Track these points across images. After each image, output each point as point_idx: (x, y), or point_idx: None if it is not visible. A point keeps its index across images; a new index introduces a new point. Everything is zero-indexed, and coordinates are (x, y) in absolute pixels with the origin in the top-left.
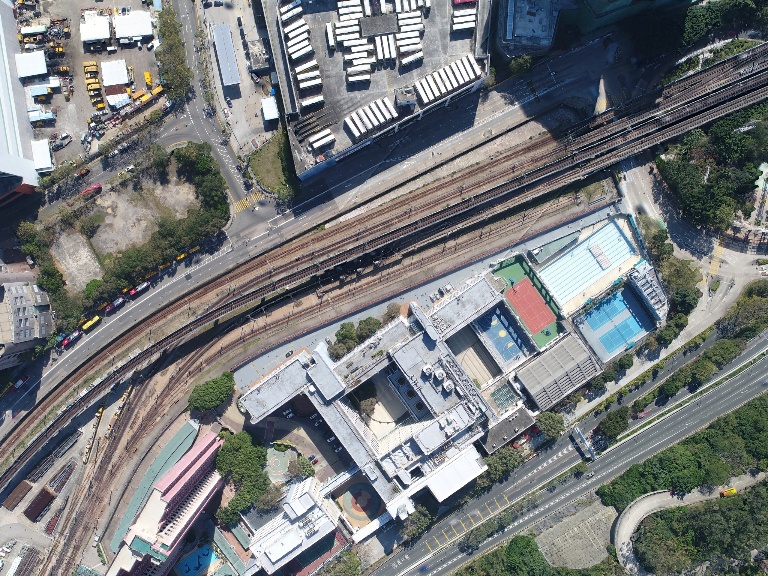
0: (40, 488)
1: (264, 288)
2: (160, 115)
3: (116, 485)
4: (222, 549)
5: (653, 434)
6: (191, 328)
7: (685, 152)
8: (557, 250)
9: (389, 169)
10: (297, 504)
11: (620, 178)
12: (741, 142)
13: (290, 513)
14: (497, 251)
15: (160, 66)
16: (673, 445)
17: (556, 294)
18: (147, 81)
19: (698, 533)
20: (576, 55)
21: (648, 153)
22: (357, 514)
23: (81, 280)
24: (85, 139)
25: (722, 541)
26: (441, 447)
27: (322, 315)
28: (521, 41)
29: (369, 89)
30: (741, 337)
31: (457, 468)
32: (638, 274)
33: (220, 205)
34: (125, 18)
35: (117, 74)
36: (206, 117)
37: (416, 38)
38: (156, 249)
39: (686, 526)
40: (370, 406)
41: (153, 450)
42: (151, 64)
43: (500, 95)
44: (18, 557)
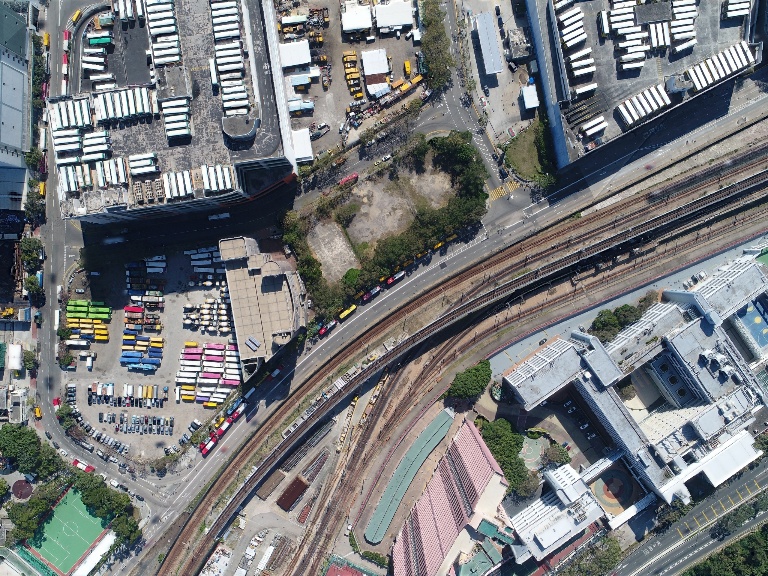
0: (293, 477)
1: (526, 276)
2: (420, 104)
3: (368, 474)
4: None
5: None
6: (453, 316)
7: None
8: None
9: (644, 157)
10: (571, 490)
11: None
12: None
13: (563, 499)
14: (750, 238)
15: (420, 55)
16: None
17: None
18: (407, 70)
19: None
20: None
21: None
22: (609, 501)
23: (336, 269)
24: (343, 128)
25: None
26: None
27: (575, 303)
28: None
29: (639, 77)
30: None
31: (732, 453)
32: None
33: None
34: (386, 7)
35: (377, 63)
36: (463, 106)
37: (690, 25)
38: (418, 238)
39: None
40: (633, 393)
41: (406, 438)
42: (409, 53)
43: (754, 83)
44: (271, 546)
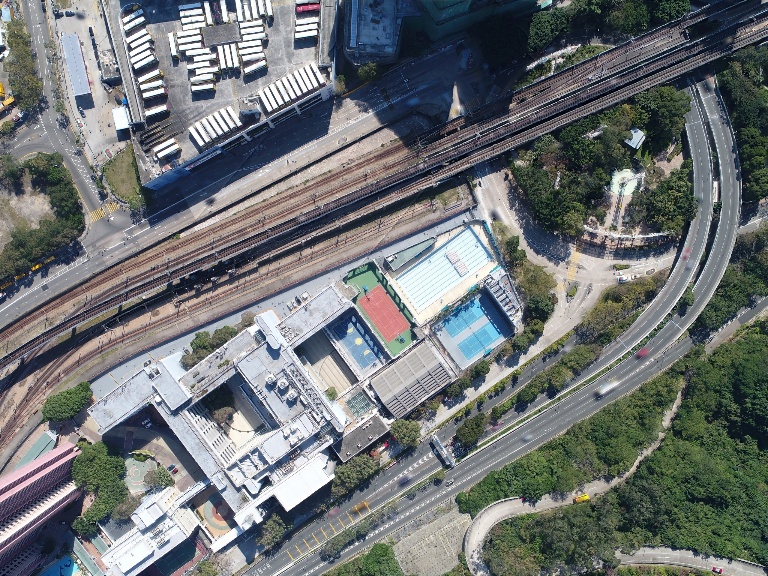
0: None
1: (116, 298)
2: (12, 126)
3: None
4: (82, 560)
5: (512, 440)
6: (44, 339)
7: (536, 158)
8: (412, 257)
9: (244, 178)
10: (145, 515)
11: (475, 184)
12: (589, 148)
13: (139, 524)
14: (353, 259)
15: None
16: (531, 451)
17: (414, 301)
18: None
19: (546, 540)
20: (429, 62)
21: (503, 159)
22: (218, 523)
23: None
24: None
25: (567, 548)
26: (289, 456)
27: (180, 324)
28: (365, 49)
29: (214, 98)
30: (597, 343)
31: (304, 477)
32: (491, 281)
33: (72, 215)
34: None
35: None
36: (60, 127)
37: (258, 47)
38: (8, 260)
39: (534, 533)
40: (223, 415)
41: (12, 461)
42: (3, 75)
43: (354, 102)
44: None
